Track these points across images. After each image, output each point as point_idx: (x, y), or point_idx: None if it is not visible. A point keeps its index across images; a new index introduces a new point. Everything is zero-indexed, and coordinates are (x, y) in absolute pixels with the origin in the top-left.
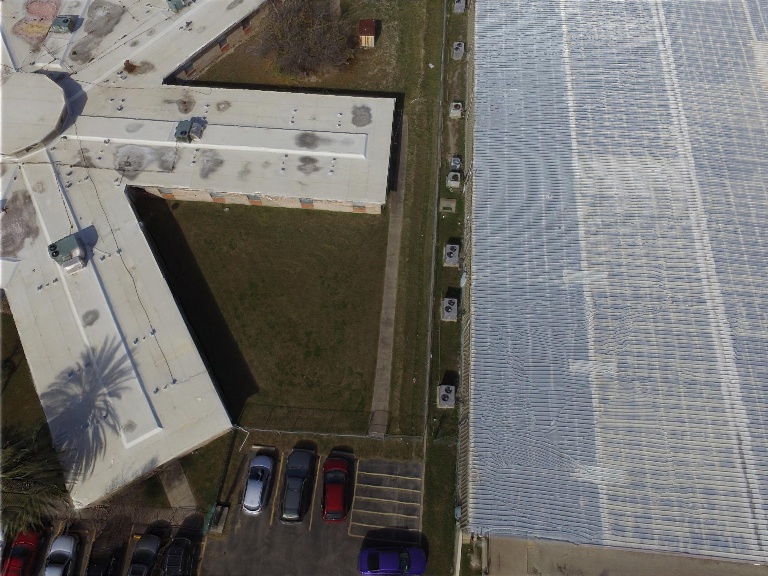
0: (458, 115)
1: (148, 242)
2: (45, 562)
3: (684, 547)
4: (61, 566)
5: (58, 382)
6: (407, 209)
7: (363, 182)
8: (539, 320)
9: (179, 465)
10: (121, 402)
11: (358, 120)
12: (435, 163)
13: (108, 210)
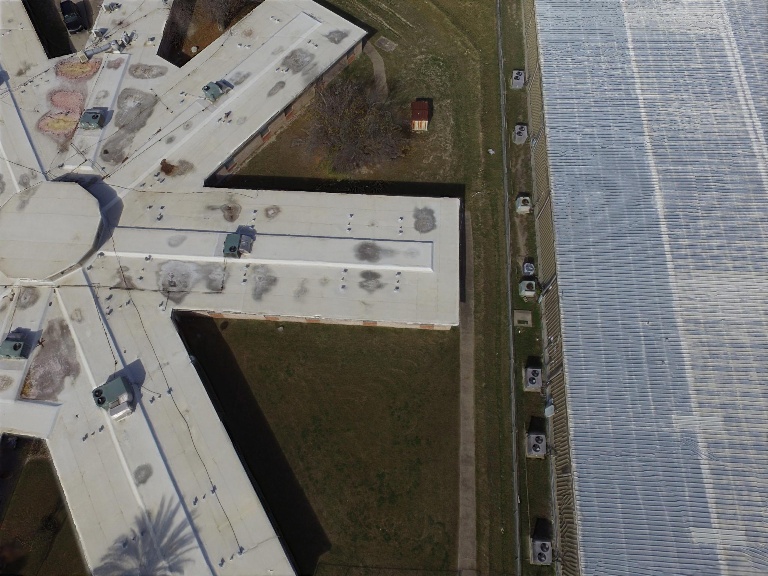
0: (526, 210)
1: (201, 378)
2: None
3: None
4: None
5: (112, 553)
6: (479, 324)
7: (433, 300)
8: (641, 463)
9: None
10: None
11: (421, 225)
12: (505, 267)
13: (154, 340)
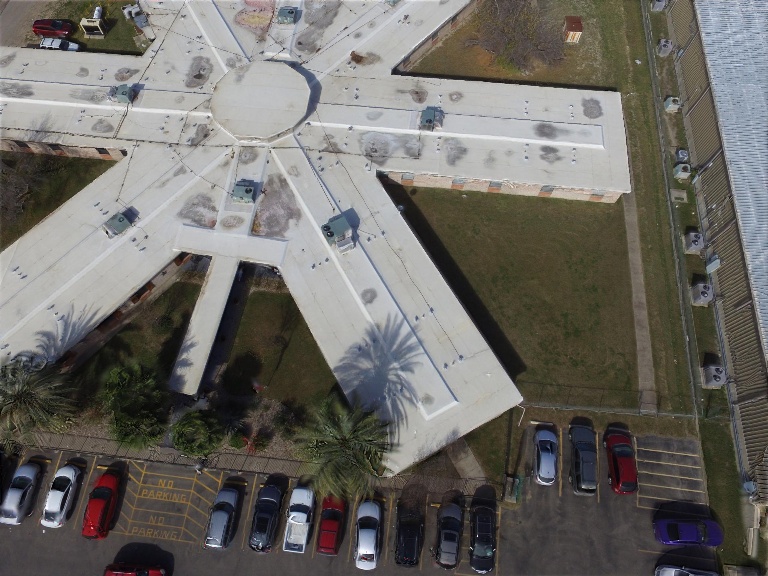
0: (675, 109)
1: (408, 225)
2: (351, 528)
3: None
4: (374, 531)
5: (348, 356)
6: (640, 199)
7: (606, 171)
8: None
9: (462, 438)
10: (415, 376)
11: (589, 112)
12: (659, 155)
13: (364, 194)
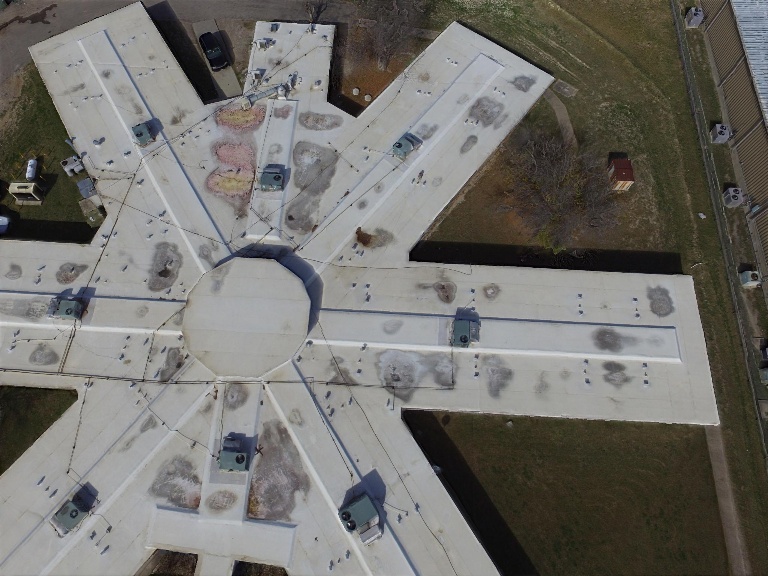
0: (753, 285)
1: (448, 491)
2: None
3: None
4: None
5: None
6: (724, 416)
7: (687, 396)
8: None
9: None
10: None
11: (658, 307)
12: (740, 350)
13: (388, 446)
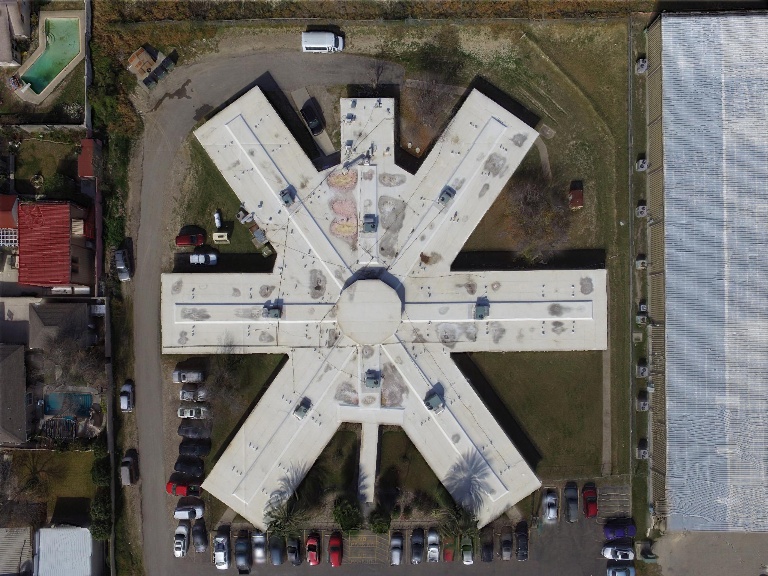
0: (643, 268)
1: (473, 389)
2: (458, 549)
3: (763, 528)
4: (470, 552)
5: (449, 473)
6: (613, 342)
7: (593, 337)
8: None
9: None
10: (485, 481)
11: (585, 289)
12: (628, 306)
13: (445, 371)
